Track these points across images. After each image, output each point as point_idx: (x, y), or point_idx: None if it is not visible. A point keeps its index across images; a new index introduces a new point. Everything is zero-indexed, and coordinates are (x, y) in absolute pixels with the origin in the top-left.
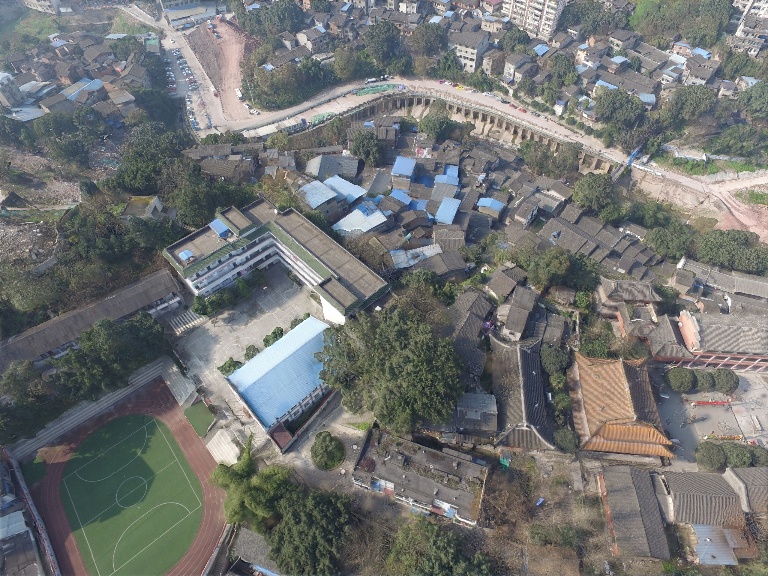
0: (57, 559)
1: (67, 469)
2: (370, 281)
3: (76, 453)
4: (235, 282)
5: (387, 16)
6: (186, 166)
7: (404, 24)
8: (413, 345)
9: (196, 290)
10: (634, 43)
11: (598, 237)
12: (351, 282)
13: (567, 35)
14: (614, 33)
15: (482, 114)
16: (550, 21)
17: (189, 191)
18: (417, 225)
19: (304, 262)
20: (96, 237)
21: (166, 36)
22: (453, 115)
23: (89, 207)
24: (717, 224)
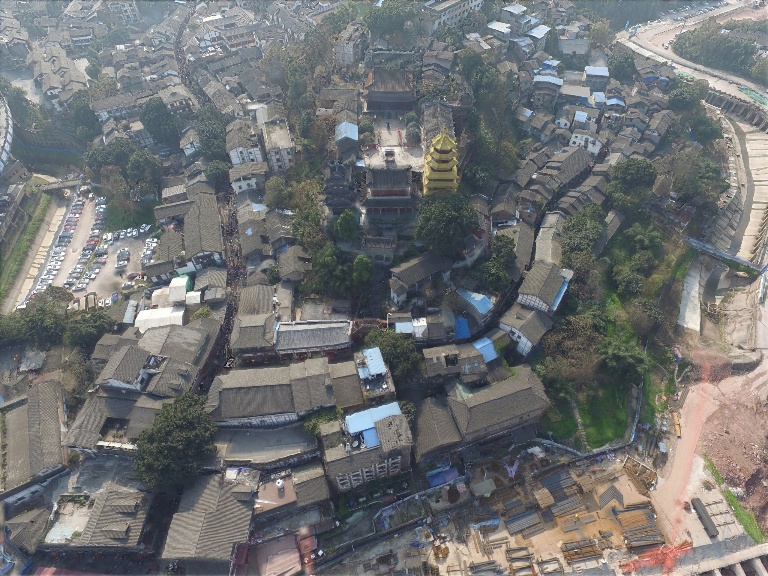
0: (332, 8)
1: (361, 4)
2: None
3: (367, 4)
4: None
5: None
6: None
7: None
8: (397, 5)
9: None
10: None
11: (582, 186)
12: (439, 5)
13: None
14: None
15: None
16: None
17: None
18: None
19: None
20: None
21: None
22: None
23: None
24: (702, 351)
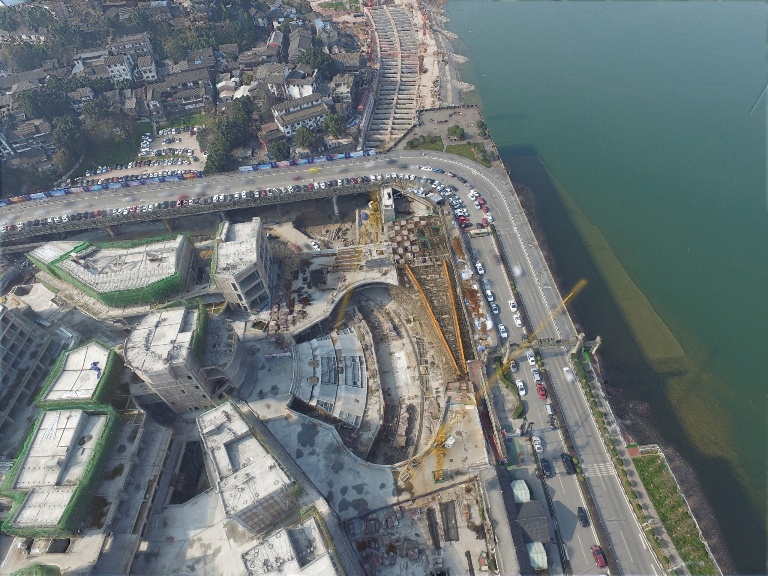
0: None
1: None
2: None
3: None
4: None
5: None
6: None
7: None
8: None
9: None
10: None
11: None
12: None
13: None
14: None
15: None
16: None
17: None
18: None
19: None
20: None
21: None
22: None
23: None
24: None
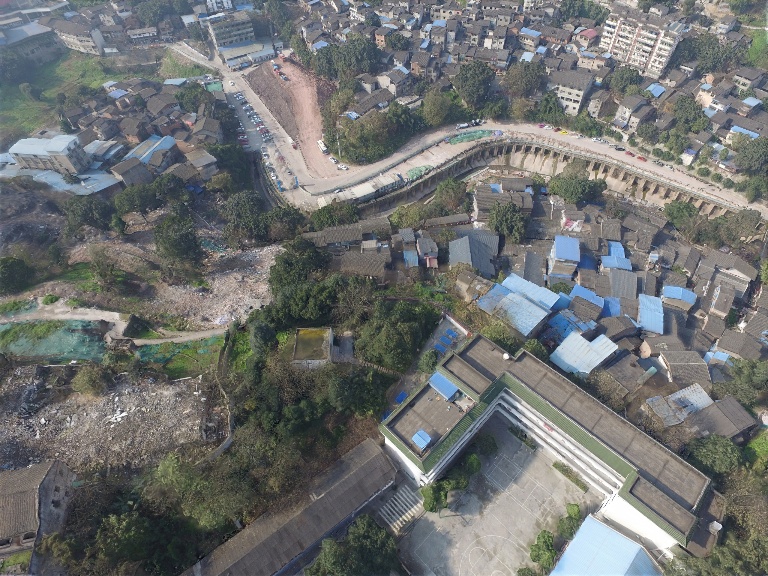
0: None
1: None
2: (679, 472)
3: None
4: (458, 452)
5: (472, 53)
6: (362, 285)
7: (491, 62)
8: None
9: (424, 477)
10: (759, 81)
11: None
12: (655, 475)
13: (684, 73)
14: (740, 71)
15: (594, 163)
16: (662, 58)
17: (393, 333)
18: (621, 336)
19: (574, 440)
20: (285, 406)
21: (223, 77)
22: (559, 163)
23: (257, 353)
24: None
